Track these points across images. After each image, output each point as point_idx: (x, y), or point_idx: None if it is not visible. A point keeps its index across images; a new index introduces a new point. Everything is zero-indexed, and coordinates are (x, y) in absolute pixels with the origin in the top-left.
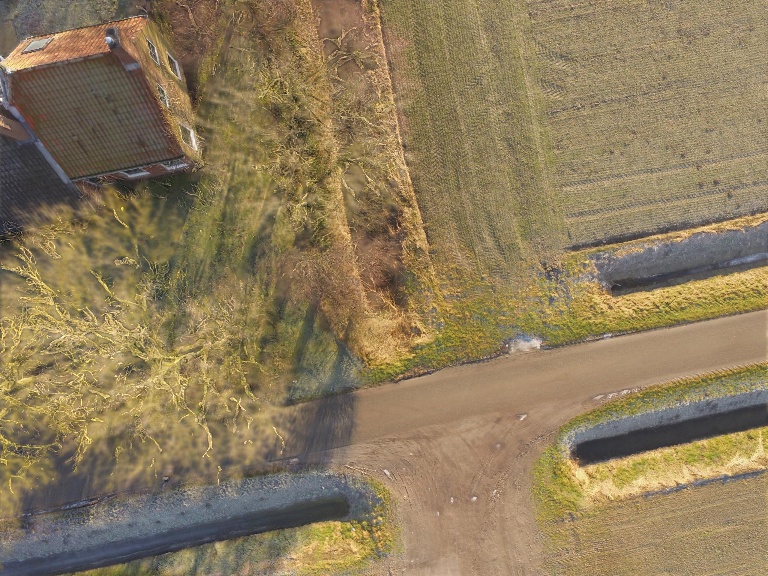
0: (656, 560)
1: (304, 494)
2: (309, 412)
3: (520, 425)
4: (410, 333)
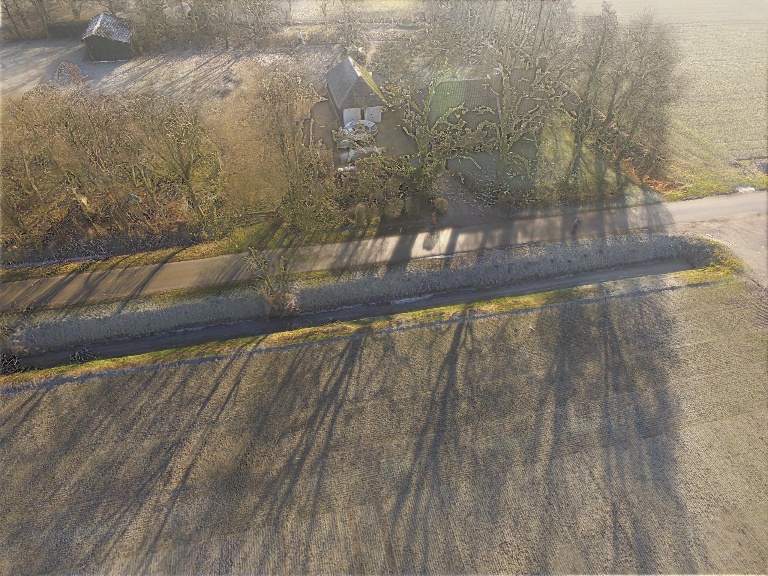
0: None
1: (660, 251)
2: (642, 210)
3: None
4: (677, 186)
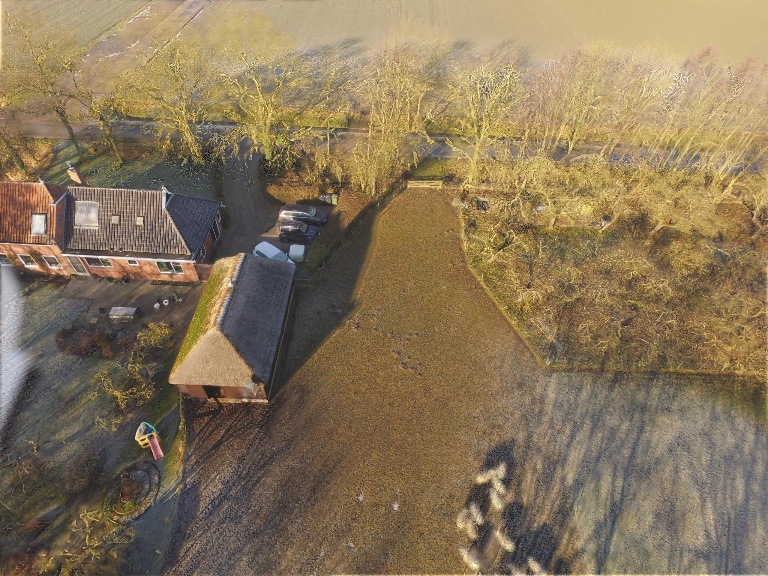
0: (2, 78)
1: None
2: None
3: (6, 117)
4: (19, 152)
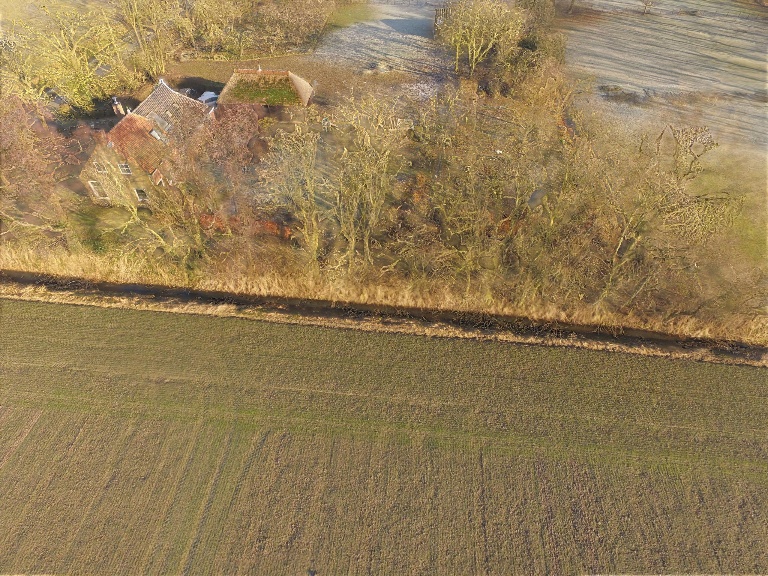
0: None
1: None
2: None
3: None
4: None
